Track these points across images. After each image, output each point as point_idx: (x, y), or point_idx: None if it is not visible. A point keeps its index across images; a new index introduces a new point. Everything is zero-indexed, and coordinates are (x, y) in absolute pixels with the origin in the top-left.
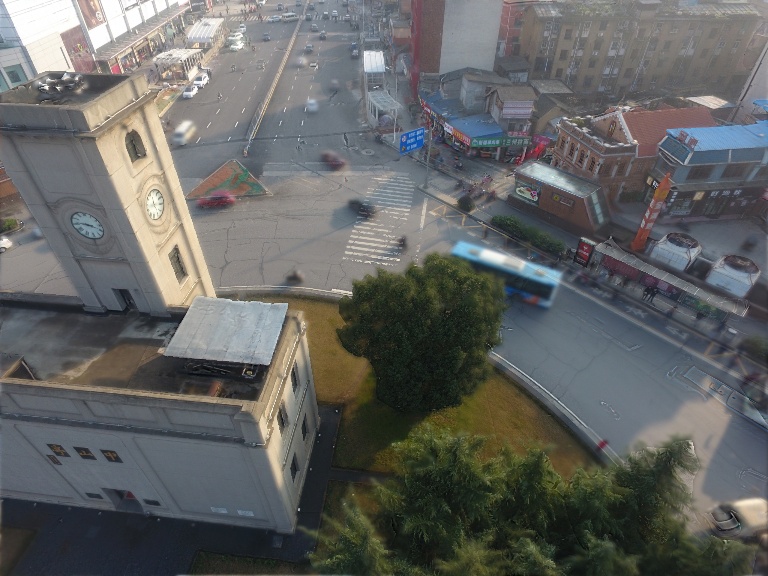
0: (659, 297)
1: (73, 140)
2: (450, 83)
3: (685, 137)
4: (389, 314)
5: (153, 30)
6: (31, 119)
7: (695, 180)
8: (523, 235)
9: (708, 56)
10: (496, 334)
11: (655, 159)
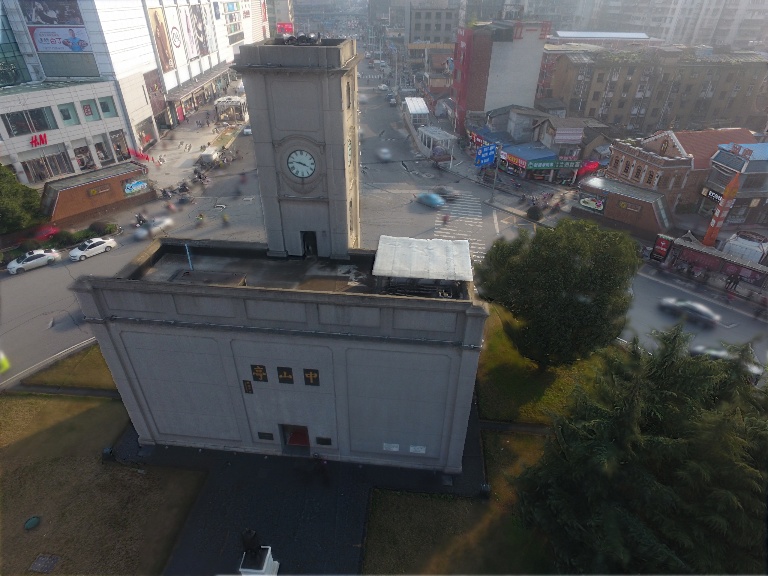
0: (742, 285)
1: (321, 77)
2: (498, 117)
3: (739, 149)
4: (541, 263)
5: (210, 80)
6: (289, 59)
7: (750, 189)
8: None
9: (726, 98)
10: (628, 291)
11: (708, 172)
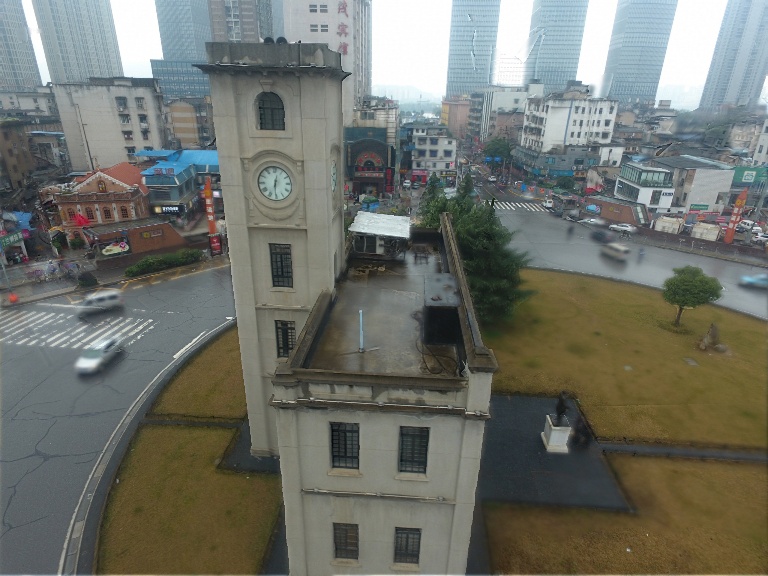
0: None
1: None
2: None
3: (161, 171)
4: None
5: None
6: (330, 62)
7: (181, 197)
8: (168, 263)
9: (13, 155)
10: None
11: (147, 196)
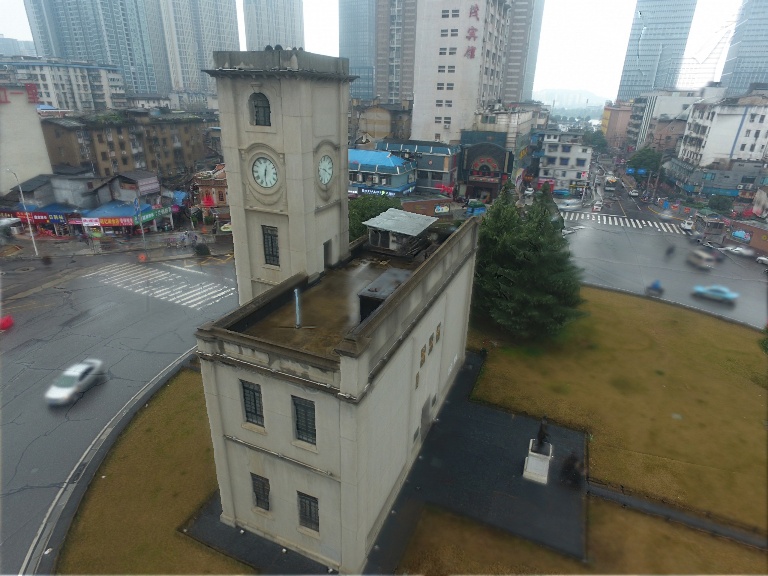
0: None
1: (339, 83)
2: (39, 190)
3: None
4: None
5: None
6: (322, 66)
7: None
8: None
9: None
10: None
11: None
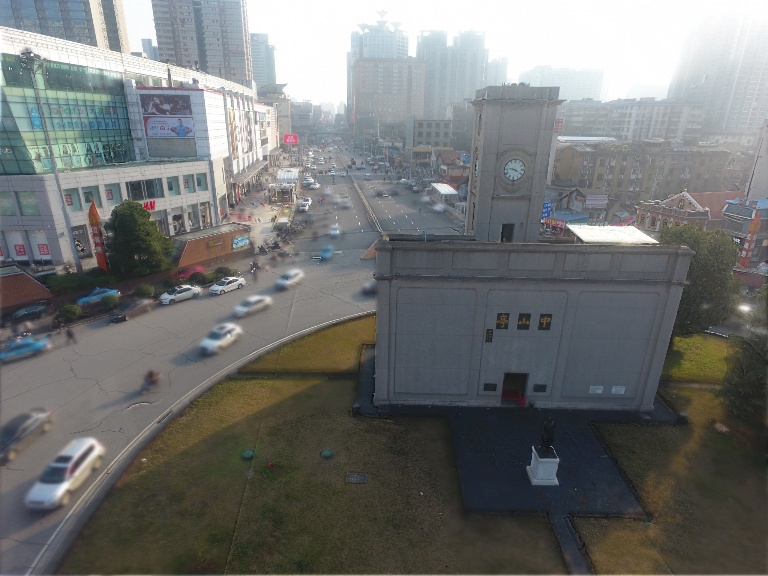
0: None
1: (543, 106)
2: None
3: (745, 202)
4: None
5: None
6: (521, 94)
7: (759, 232)
8: None
9: (701, 179)
10: None
11: (721, 222)
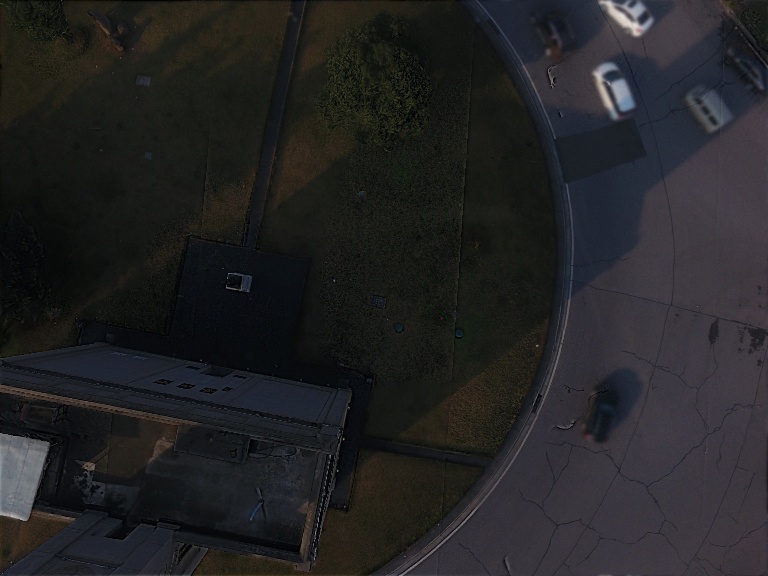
0: None
1: None
2: None
3: None
4: None
5: None
6: None
7: None
8: None
9: None
10: None
11: None
